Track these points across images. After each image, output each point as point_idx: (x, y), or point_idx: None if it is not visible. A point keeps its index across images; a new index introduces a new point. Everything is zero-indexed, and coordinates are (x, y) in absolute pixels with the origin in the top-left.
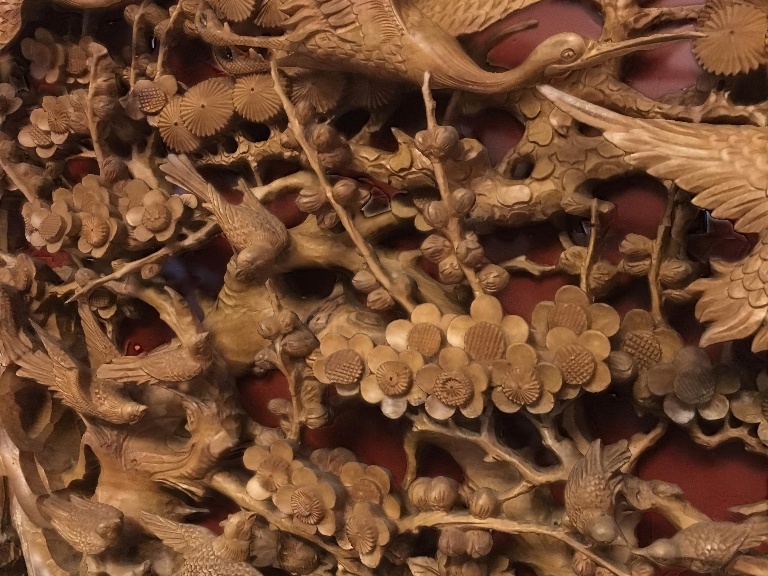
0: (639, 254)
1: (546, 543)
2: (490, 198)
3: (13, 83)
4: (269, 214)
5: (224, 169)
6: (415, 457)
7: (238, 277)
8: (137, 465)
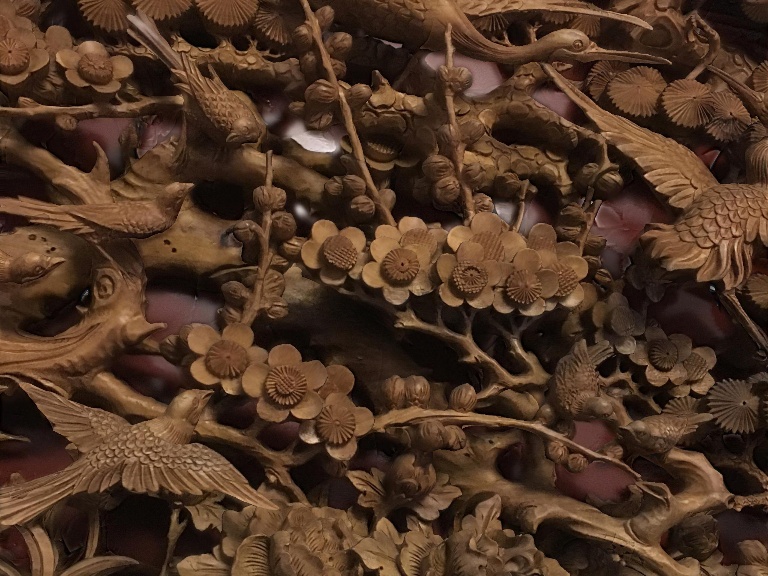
0: (579, 219)
1: (480, 460)
2: None
3: None
4: None
5: (142, 64)
6: None
7: (171, 163)
8: None
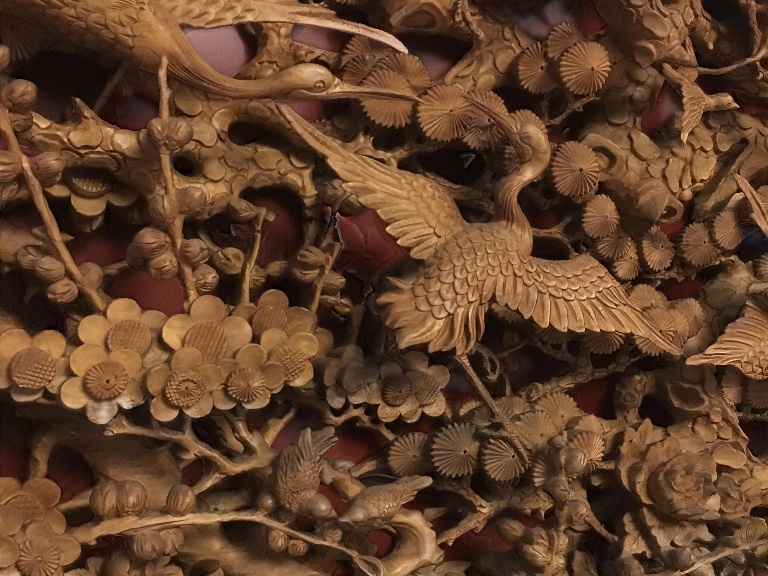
0: (317, 265)
1: (205, 530)
2: None
3: None
4: None
5: None
6: (47, 463)
7: None
8: None
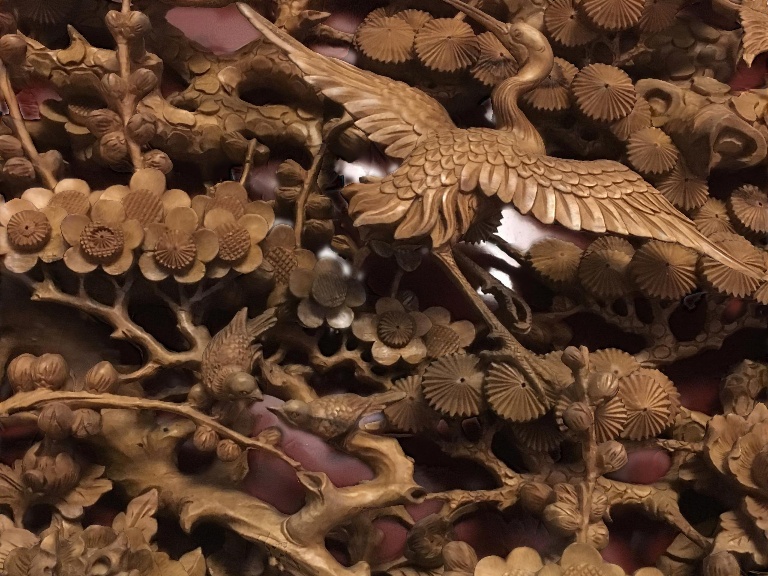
0: (294, 177)
1: (151, 451)
2: (156, 112)
3: None
4: None
5: None
6: (5, 366)
7: None
8: None
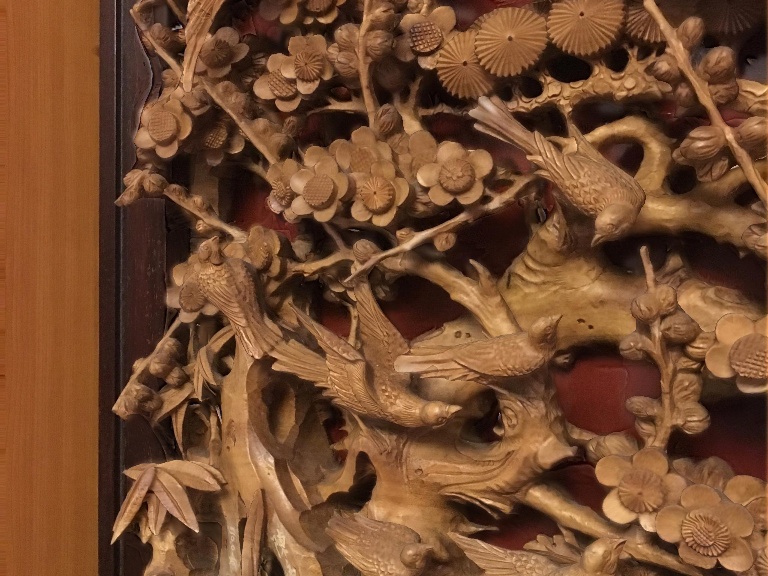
0: None
1: None
2: None
3: (236, 26)
4: (616, 167)
5: (519, 118)
6: None
7: (559, 247)
8: (423, 476)
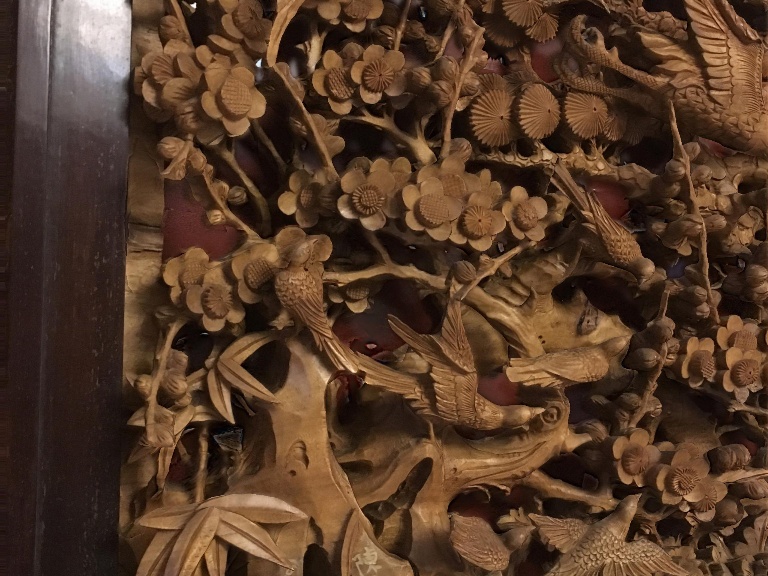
0: None
1: None
2: None
3: None
4: None
5: (509, 169)
6: None
7: (560, 281)
8: (458, 473)
